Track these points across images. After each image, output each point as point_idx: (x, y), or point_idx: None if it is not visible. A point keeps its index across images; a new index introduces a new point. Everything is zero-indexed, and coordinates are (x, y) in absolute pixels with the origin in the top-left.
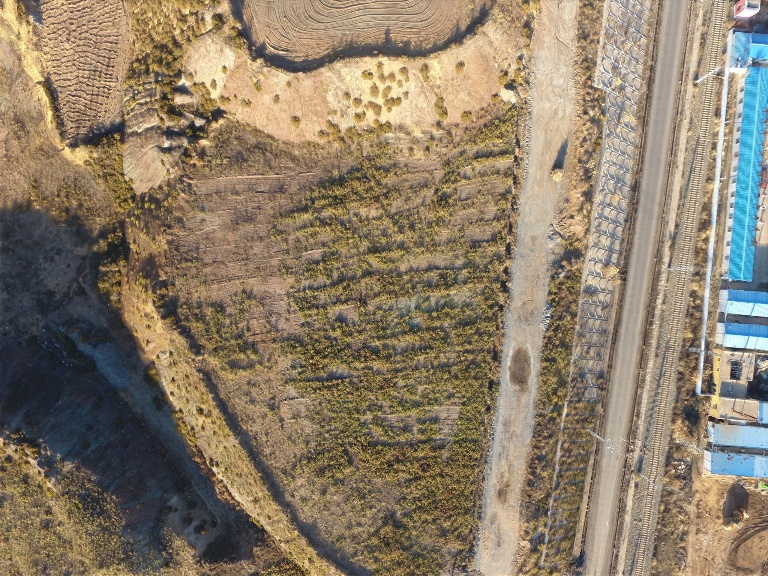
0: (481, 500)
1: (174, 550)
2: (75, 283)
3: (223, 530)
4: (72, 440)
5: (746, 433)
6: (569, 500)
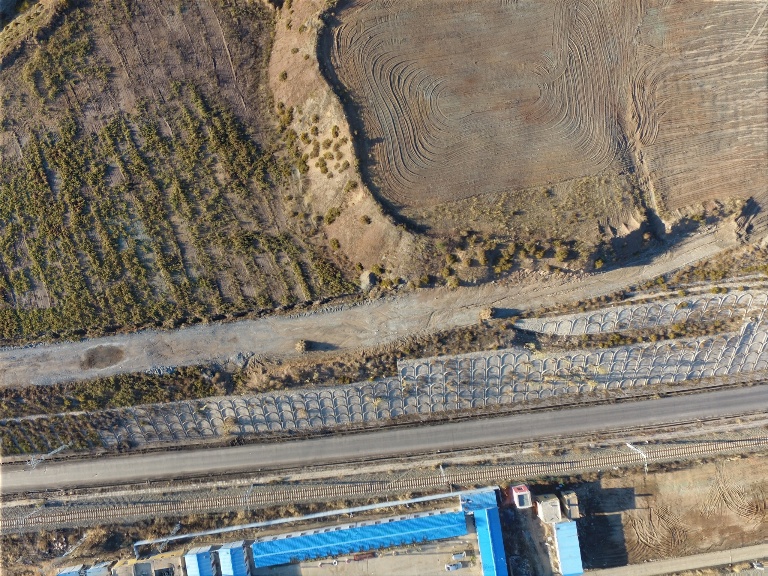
0: None
1: None
2: None
3: None
4: None
5: None
6: None
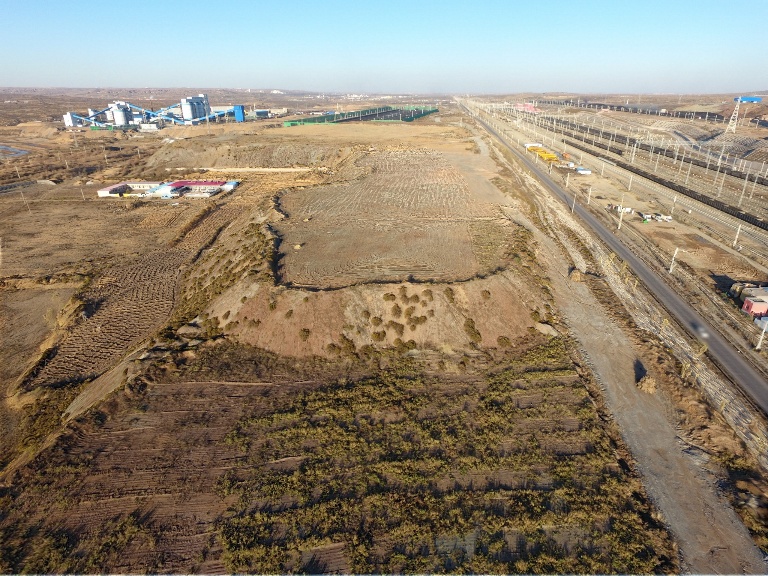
0: None
1: None
2: None
3: None
4: None
5: None
6: None
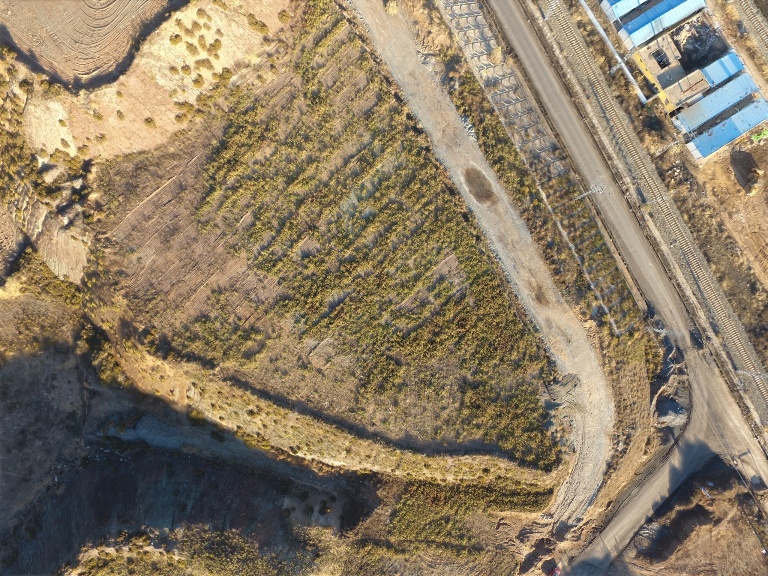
0: (527, 315)
1: (314, 540)
2: (84, 391)
3: (344, 498)
4: (169, 511)
5: (708, 103)
6: (602, 266)
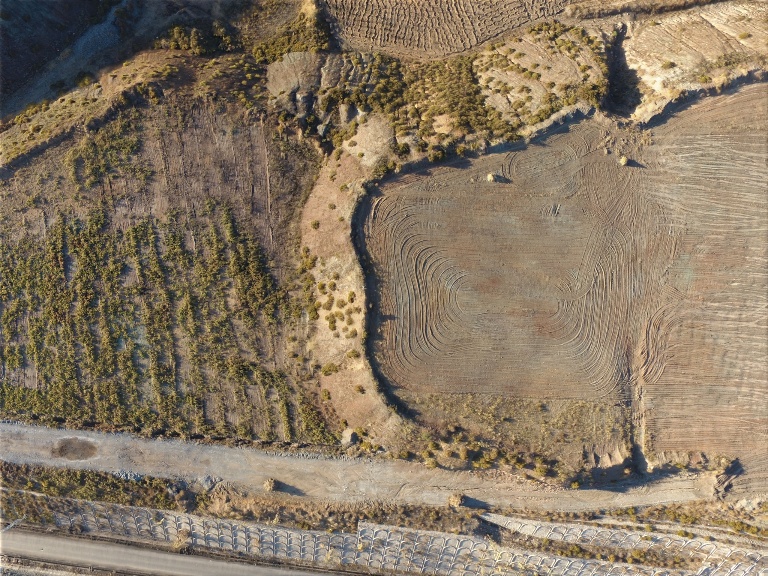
0: None
1: None
2: (183, 4)
3: None
4: (9, 2)
5: None
6: None
